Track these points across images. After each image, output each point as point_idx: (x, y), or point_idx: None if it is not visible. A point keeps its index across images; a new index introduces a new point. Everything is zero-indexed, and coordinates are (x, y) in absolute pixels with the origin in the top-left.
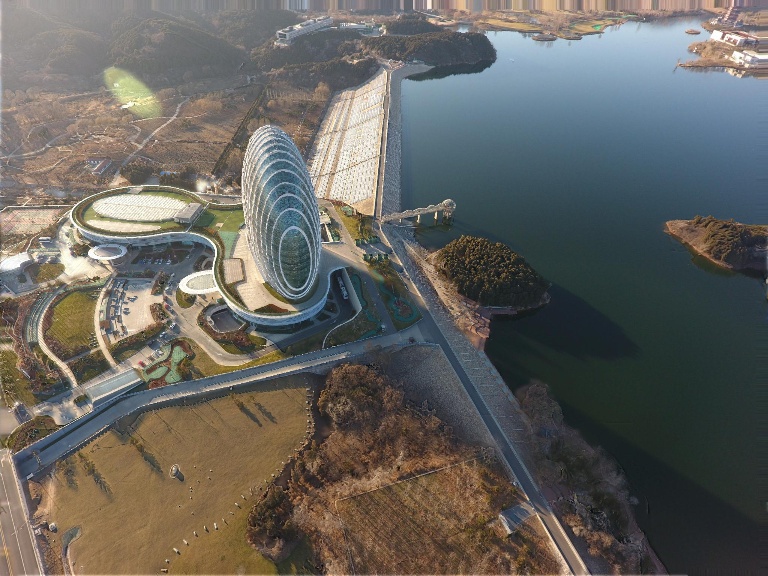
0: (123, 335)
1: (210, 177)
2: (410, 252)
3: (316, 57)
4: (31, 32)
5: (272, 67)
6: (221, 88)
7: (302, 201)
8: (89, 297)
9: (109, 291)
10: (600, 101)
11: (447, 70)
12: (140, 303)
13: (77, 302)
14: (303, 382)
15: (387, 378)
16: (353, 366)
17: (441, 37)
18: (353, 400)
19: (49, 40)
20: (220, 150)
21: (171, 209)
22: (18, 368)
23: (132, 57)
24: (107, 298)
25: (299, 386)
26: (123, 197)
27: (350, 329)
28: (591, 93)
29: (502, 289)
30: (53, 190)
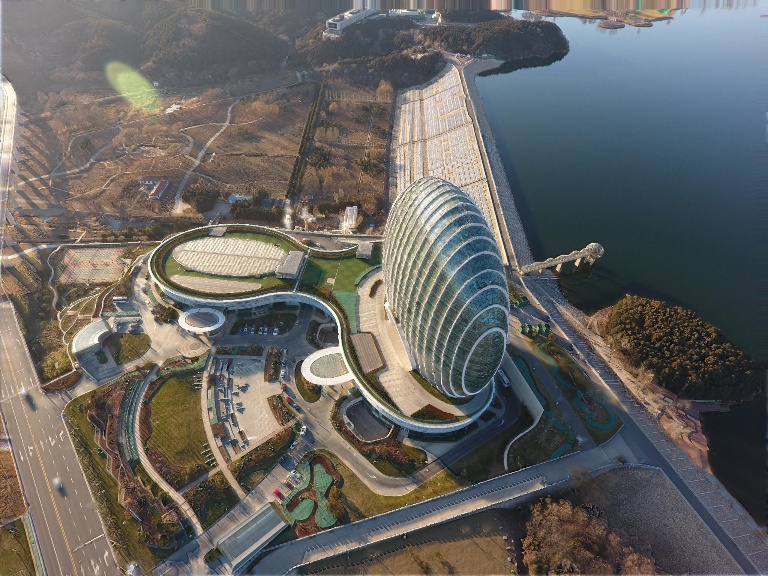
0: (244, 446)
1: (285, 202)
2: (566, 316)
3: (370, 50)
4: (56, 22)
5: (323, 61)
6: (271, 87)
7: (505, 292)
8: (190, 386)
9: (213, 377)
10: (721, 108)
11: (516, 64)
12: (254, 394)
13: (177, 395)
14: (495, 526)
15: (626, 536)
16: (568, 510)
17: (510, 27)
18: (577, 563)
19: (77, 31)
20: (288, 166)
21: (268, 259)
22: (122, 503)
23: (172, 52)
24: (213, 388)
25: (492, 532)
26: (206, 241)
27: (536, 441)
28: (709, 98)
29: (712, 380)
30: (108, 219)
